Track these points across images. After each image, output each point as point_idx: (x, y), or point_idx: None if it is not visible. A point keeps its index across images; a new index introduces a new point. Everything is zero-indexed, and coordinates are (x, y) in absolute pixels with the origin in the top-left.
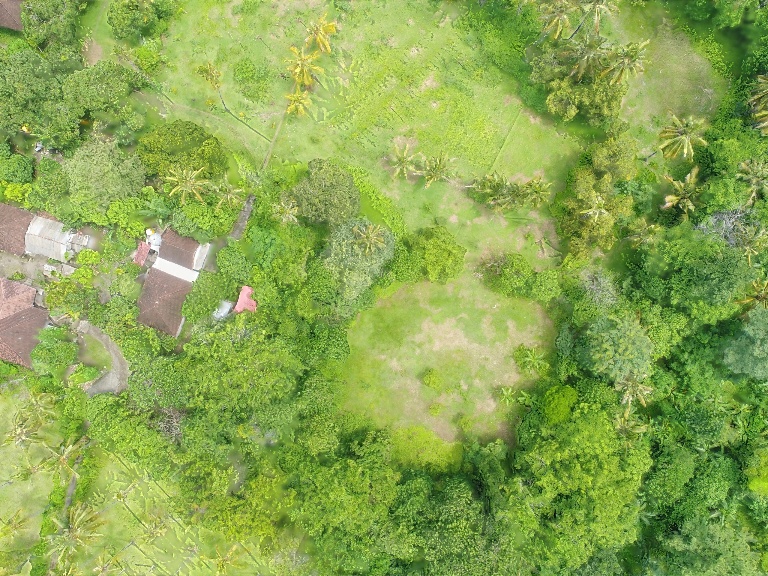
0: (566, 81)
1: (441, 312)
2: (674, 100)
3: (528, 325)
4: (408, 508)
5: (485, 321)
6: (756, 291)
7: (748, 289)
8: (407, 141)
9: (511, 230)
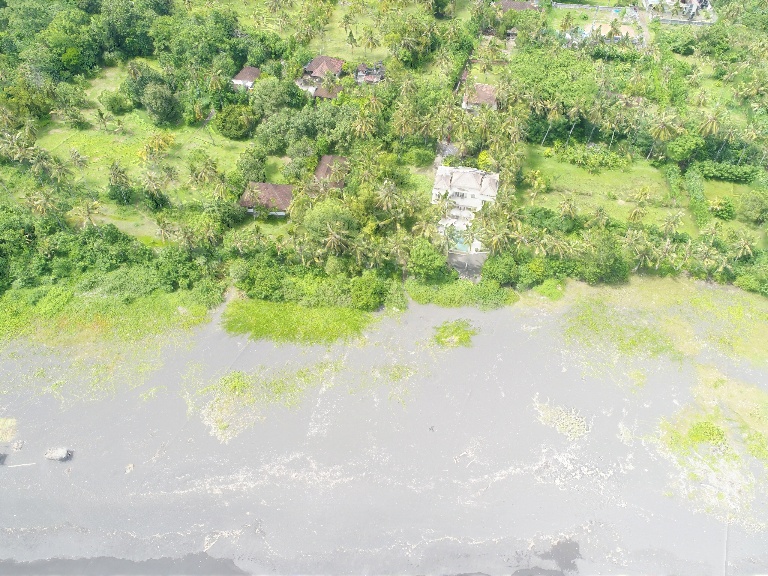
0: None
1: None
2: None
3: None
4: (144, 22)
5: None
6: None
7: None
8: (118, 140)
9: None
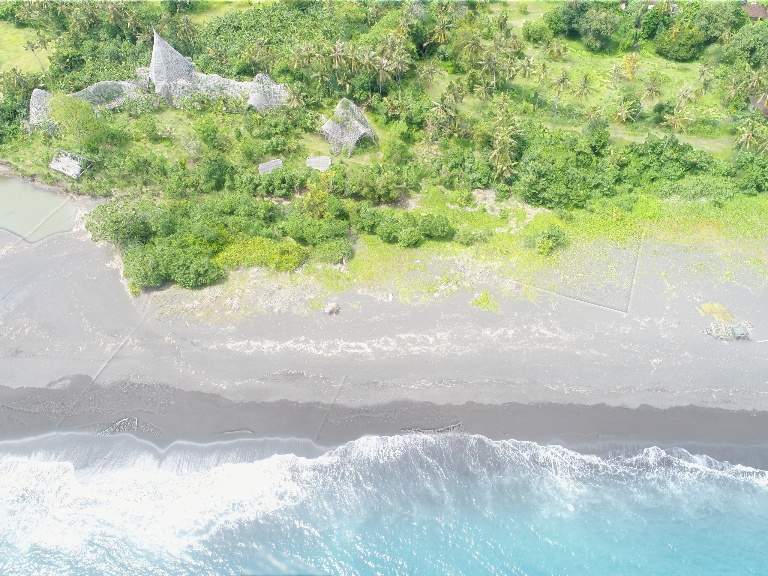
0: None
1: None
2: None
3: None
4: None
5: None
6: None
7: None
8: (564, 67)
9: None
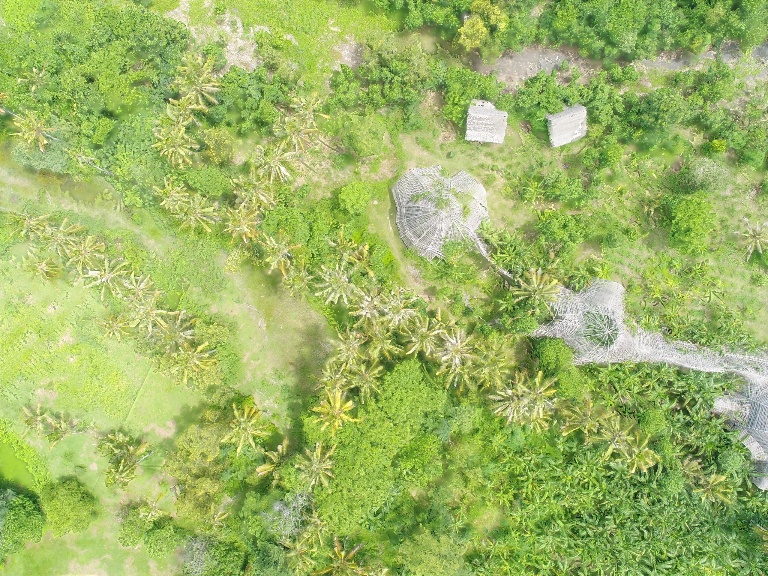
0: (165, 357)
1: (86, 553)
2: (295, 354)
3: (168, 564)
4: None
5: (127, 561)
6: (332, 563)
7: (327, 559)
8: (47, 393)
9: (147, 477)
